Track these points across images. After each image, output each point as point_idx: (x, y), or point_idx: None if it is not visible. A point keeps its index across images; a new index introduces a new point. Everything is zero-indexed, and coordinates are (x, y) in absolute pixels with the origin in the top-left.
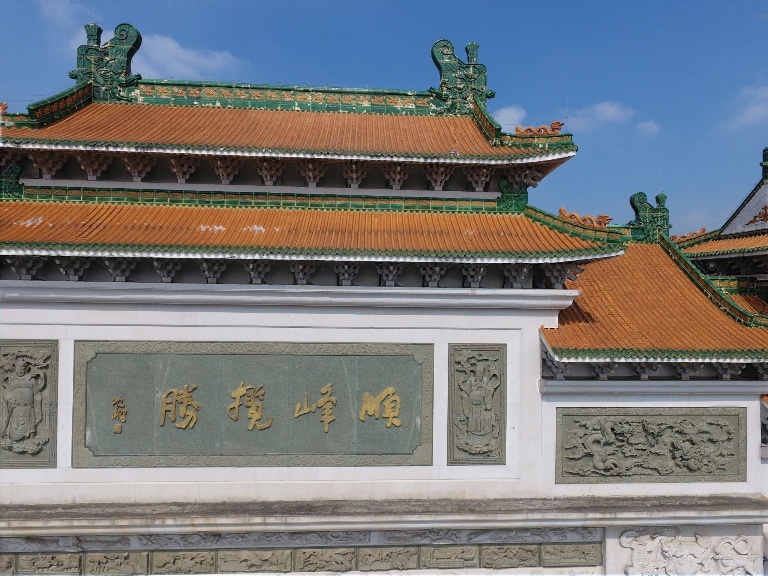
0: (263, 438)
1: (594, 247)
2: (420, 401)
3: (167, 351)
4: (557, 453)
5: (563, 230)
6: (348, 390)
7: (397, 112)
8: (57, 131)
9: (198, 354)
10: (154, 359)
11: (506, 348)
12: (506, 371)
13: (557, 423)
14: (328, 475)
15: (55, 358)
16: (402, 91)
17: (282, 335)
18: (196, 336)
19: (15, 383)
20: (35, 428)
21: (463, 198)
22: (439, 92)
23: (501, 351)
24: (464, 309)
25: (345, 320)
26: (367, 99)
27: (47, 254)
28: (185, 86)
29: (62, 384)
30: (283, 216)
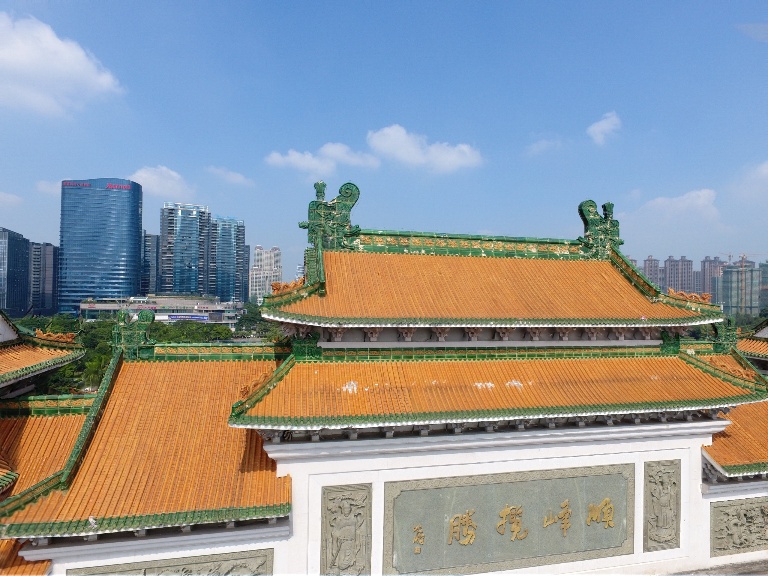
0: (521, 546)
1: (748, 394)
2: (626, 506)
3: (453, 485)
4: (711, 535)
5: (715, 375)
6: (579, 503)
7: (557, 258)
8: (340, 298)
9: (476, 485)
10: (444, 492)
11: (680, 462)
12: (680, 479)
13: (710, 513)
14: (566, 569)
15: (370, 498)
16: (560, 240)
17: (534, 465)
18: (474, 471)
19: (344, 523)
20: (356, 557)
21: (638, 345)
22: (587, 242)
23: (677, 465)
24: (656, 437)
25: (578, 450)
26: (535, 247)
27: (394, 425)
28: (396, 236)
29: (375, 518)
30: (522, 367)
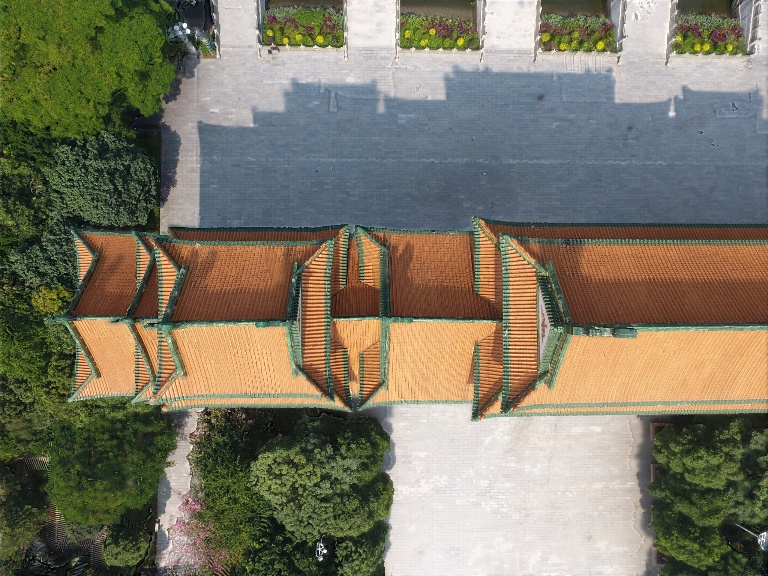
0: None
1: None
2: None
3: None
4: None
5: None
6: None
7: None
8: (559, 382)
9: None
10: None
11: None
12: None
13: None
14: None
15: None
16: None
17: None
18: None
19: None
20: None
21: None
22: None
23: None
24: None
25: None
26: None
27: None
28: None
29: None
30: None
